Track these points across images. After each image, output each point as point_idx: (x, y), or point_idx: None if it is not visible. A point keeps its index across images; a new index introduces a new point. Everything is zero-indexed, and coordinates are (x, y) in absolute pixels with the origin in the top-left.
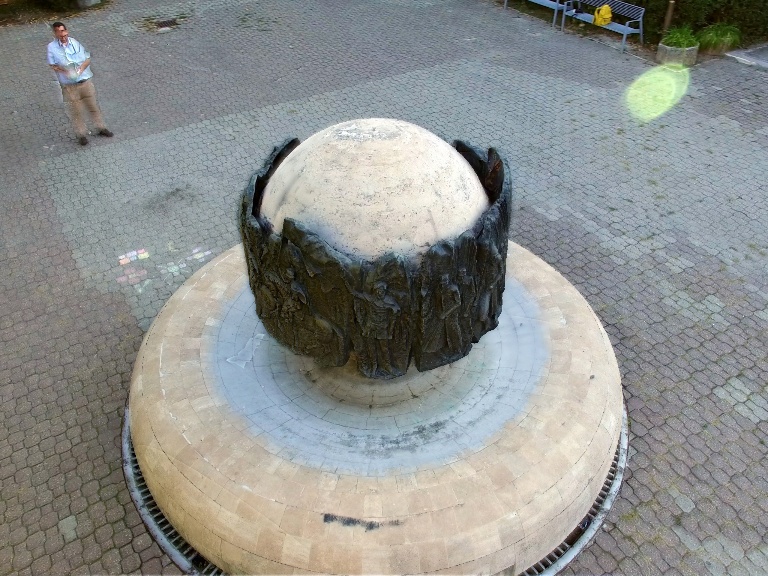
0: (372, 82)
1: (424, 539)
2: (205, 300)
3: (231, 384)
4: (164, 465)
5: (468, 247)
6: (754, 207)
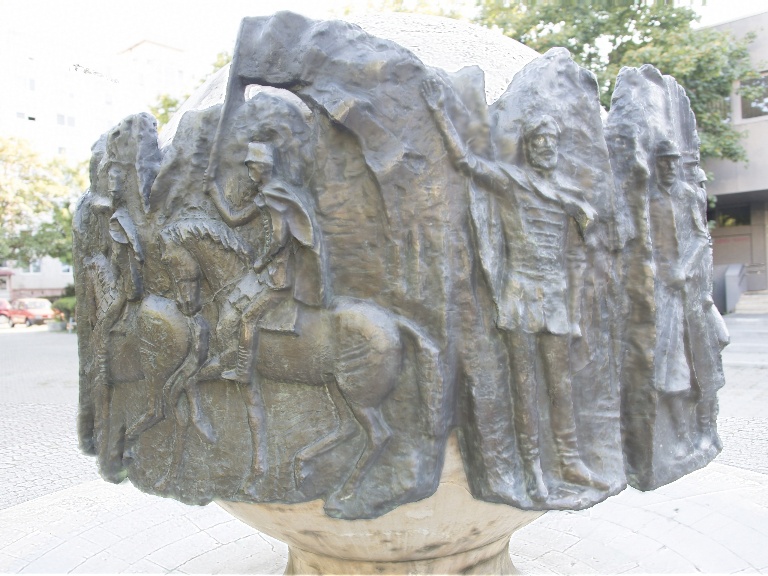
0: None
1: None
2: None
3: None
4: None
5: None
6: (765, 434)
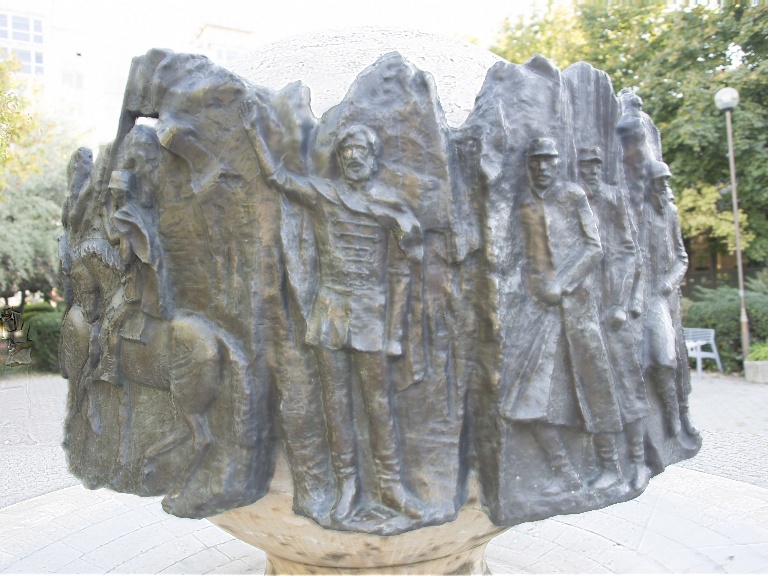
0: None
1: None
2: (4, 524)
3: None
4: None
5: (595, 96)
6: None
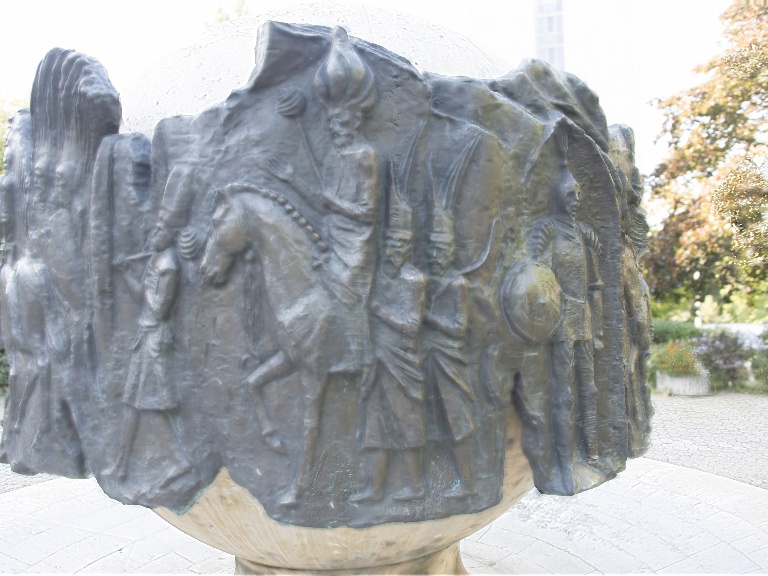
0: None
1: None
2: None
3: None
4: None
5: None
6: None
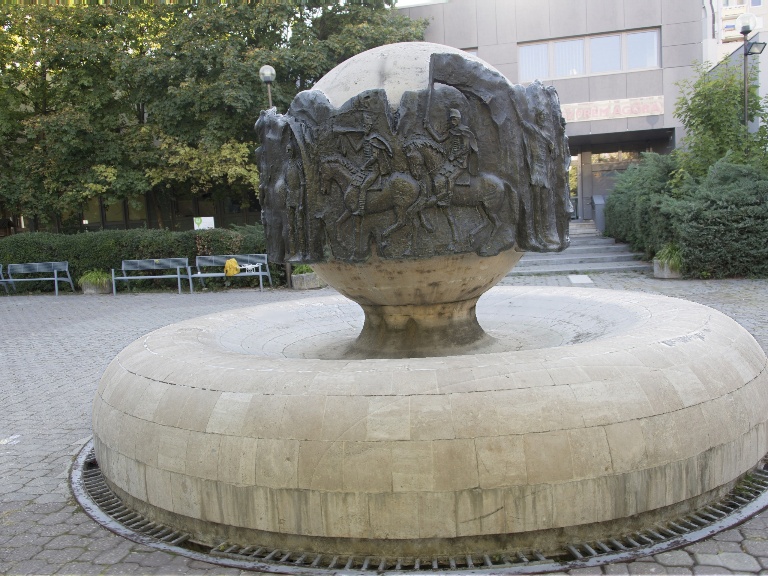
0: (35, 333)
1: (735, 336)
2: None
3: None
4: (430, 406)
5: None
6: None
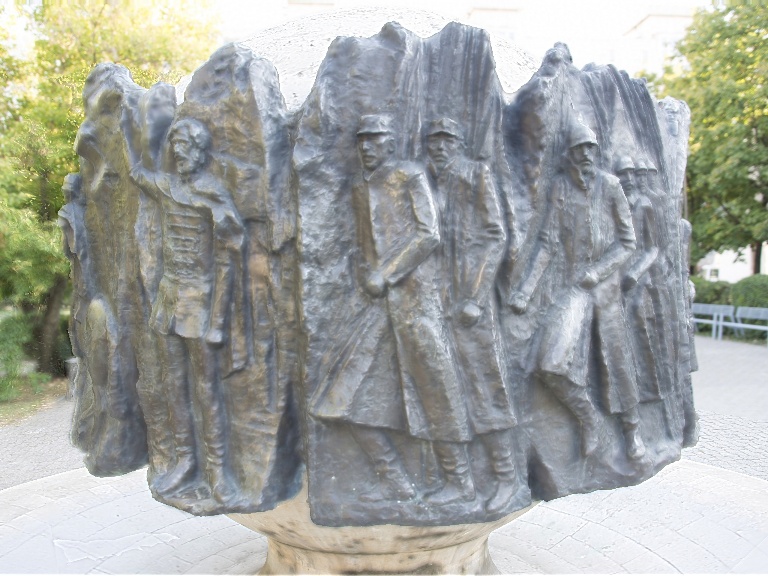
0: None
1: None
2: None
3: (3, 570)
4: None
5: (466, 60)
6: None
